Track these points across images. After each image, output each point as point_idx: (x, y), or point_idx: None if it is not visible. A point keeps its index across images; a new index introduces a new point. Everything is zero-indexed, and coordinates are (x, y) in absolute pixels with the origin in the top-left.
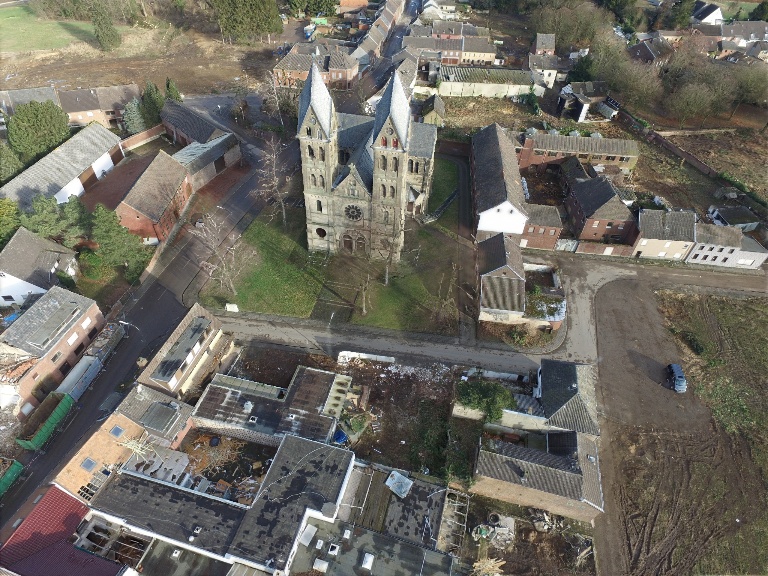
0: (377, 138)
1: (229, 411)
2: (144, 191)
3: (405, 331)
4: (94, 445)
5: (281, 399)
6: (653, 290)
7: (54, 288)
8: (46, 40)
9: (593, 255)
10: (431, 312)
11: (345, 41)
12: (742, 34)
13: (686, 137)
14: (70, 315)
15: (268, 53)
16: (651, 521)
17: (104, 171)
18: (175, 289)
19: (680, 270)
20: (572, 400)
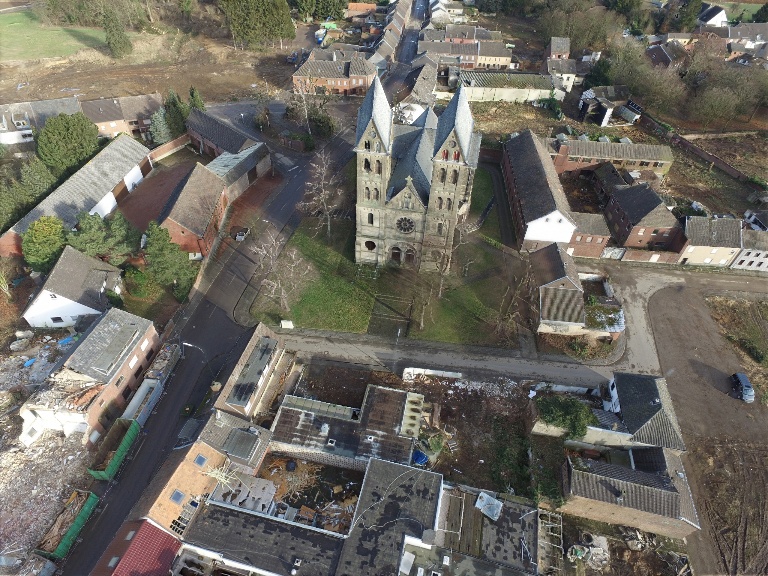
0: (439, 151)
1: (305, 434)
2: (187, 205)
3: (465, 345)
4: (181, 476)
5: (356, 420)
6: (704, 297)
7: (113, 310)
8: (54, 47)
9: (639, 262)
10: (488, 325)
11: (360, 46)
12: (749, 36)
13: (710, 140)
14: (131, 338)
15: (281, 59)
16: (742, 536)
17: (134, 184)
18: (225, 306)
19: (726, 276)
20: (657, 415)
